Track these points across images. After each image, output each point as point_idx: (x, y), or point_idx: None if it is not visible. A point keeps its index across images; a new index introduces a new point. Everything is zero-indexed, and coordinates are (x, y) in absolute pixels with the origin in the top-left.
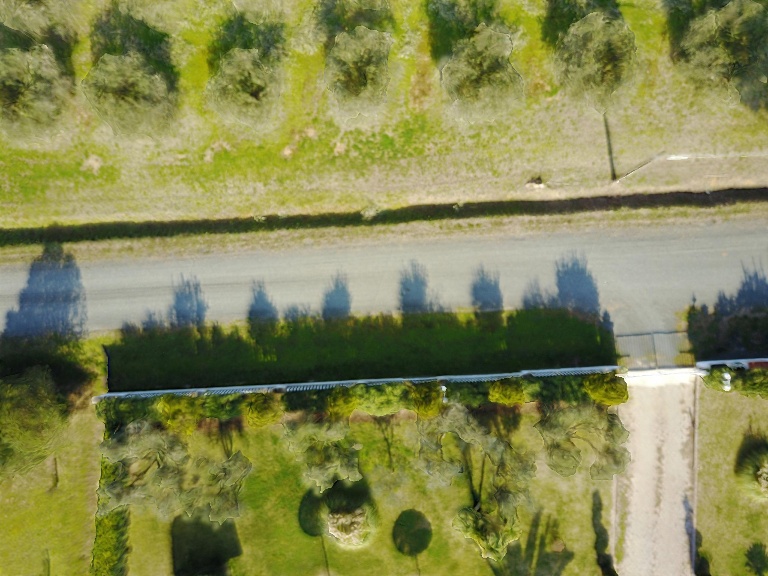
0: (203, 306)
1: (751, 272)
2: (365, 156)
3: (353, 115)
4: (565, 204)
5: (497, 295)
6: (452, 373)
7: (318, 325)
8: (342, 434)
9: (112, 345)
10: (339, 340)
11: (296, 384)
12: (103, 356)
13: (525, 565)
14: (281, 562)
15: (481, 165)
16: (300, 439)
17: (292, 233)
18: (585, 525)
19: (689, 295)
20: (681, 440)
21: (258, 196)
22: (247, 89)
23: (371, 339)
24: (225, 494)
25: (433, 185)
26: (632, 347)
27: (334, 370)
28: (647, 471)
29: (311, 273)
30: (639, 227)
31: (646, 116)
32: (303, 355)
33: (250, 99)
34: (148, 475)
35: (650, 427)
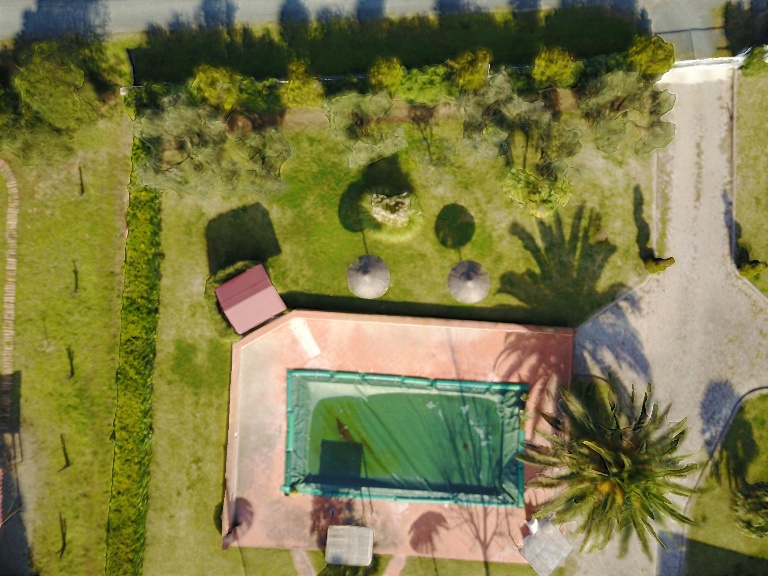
0: (233, 7)
1: None
2: None
3: None
4: None
5: None
6: None
7: (353, 27)
8: (387, 102)
9: (137, 49)
10: (375, 42)
11: None
12: (127, 65)
13: (568, 257)
14: (321, 260)
15: None
16: (344, 106)
17: None
18: (627, 219)
19: None
20: (719, 135)
21: None
22: None
23: (407, 41)
24: None
25: None
26: None
27: None
28: (686, 167)
29: None
30: None
31: None
32: (338, 58)
33: None
34: (182, 166)
35: (689, 123)
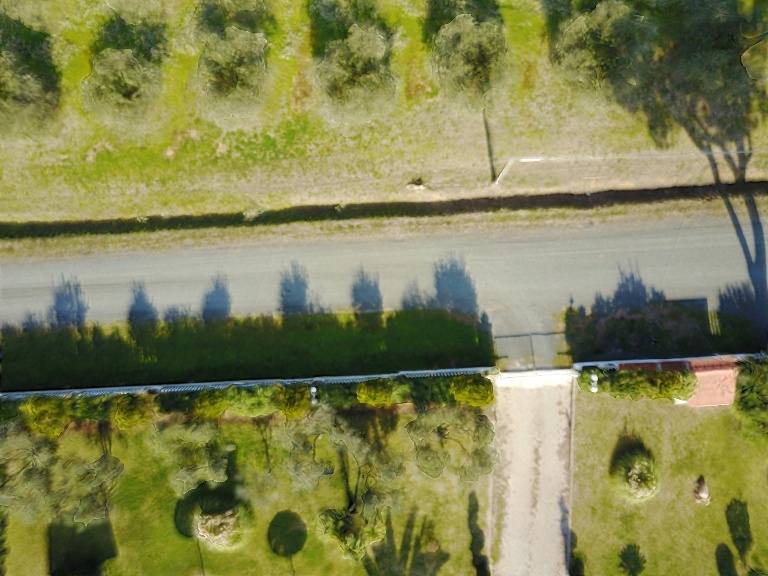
0: (83, 307)
1: (627, 274)
2: (247, 157)
3: (226, 116)
4: (447, 205)
5: (377, 296)
6: (331, 374)
7: (199, 326)
8: (208, 435)
9: None
10: (219, 341)
11: (174, 385)
12: None
13: (400, 566)
14: (156, 563)
15: (362, 166)
16: (165, 440)
17: (173, 234)
18: (461, 526)
19: (566, 296)
20: (558, 441)
21: (141, 196)
22: (121, 89)
23: (251, 340)
24: (93, 495)
25: (315, 186)
26: (510, 348)
27: (214, 371)
28: (524, 472)
29: (192, 274)
30: (517, 228)
31: (526, 118)
32: (183, 356)
33: (122, 99)
34: (21, 476)
35: (527, 428)
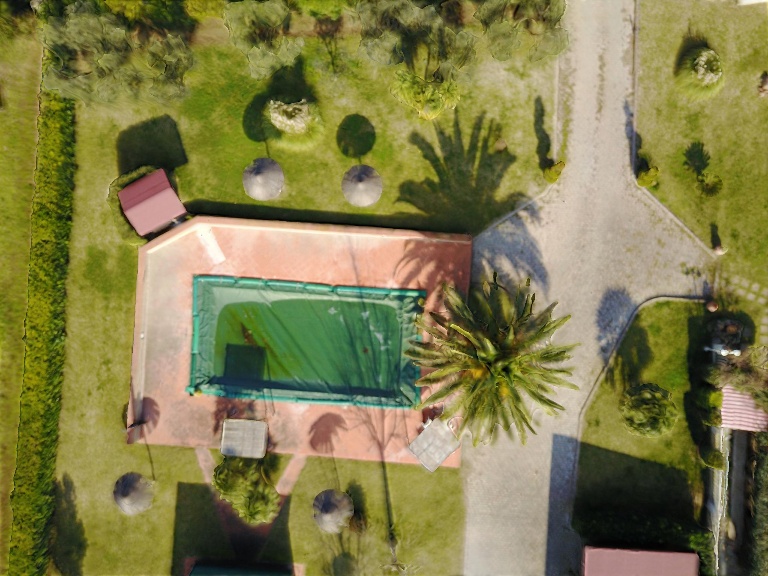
0: None
1: None
2: None
3: None
4: None
5: None
6: None
7: None
8: (280, 8)
9: None
10: None
11: None
12: None
13: (467, 166)
14: (226, 169)
15: None
16: (238, 12)
17: None
18: (527, 130)
19: None
20: (622, 47)
21: None
22: None
23: None
24: None
25: None
26: None
27: None
28: (588, 79)
29: None
30: None
31: None
32: None
33: None
34: None
35: (591, 36)
